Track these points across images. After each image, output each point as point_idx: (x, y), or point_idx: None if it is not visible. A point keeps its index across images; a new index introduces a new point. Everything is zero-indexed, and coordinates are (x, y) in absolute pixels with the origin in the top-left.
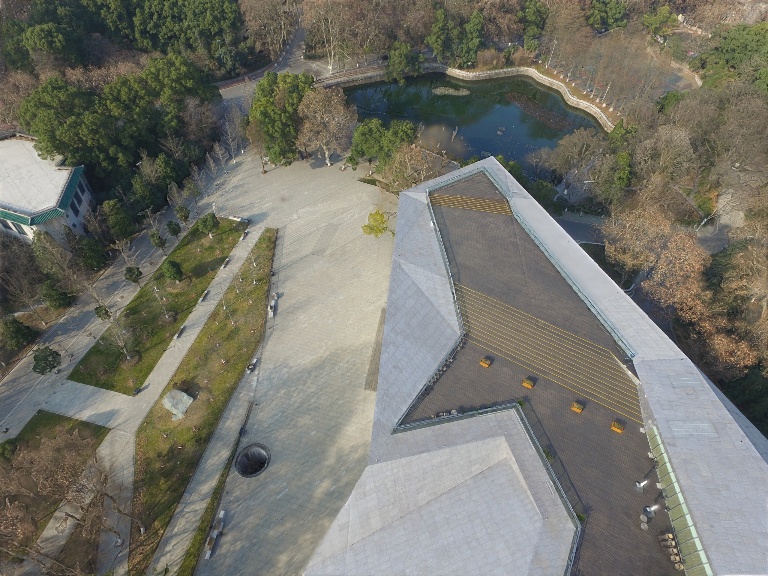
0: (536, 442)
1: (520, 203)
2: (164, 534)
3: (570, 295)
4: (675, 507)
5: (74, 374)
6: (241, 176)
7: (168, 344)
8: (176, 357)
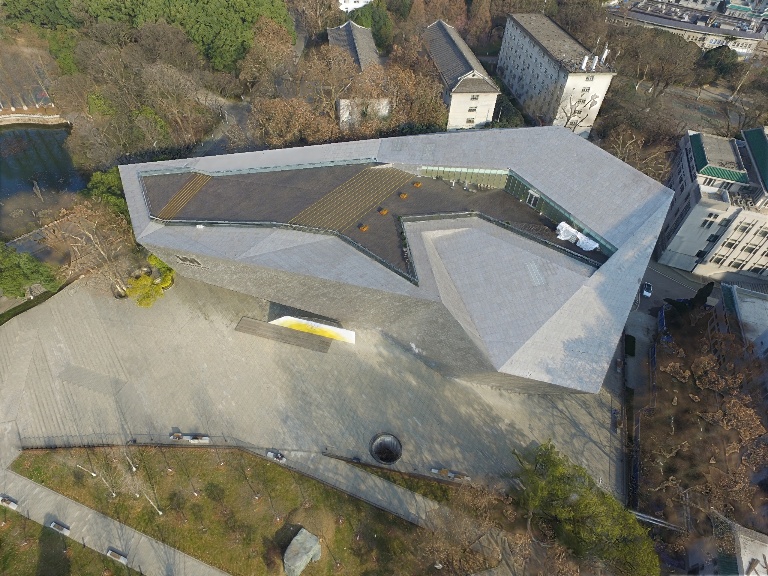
0: None
1: (202, 166)
2: None
3: (314, 171)
4: (466, 177)
5: None
6: None
7: None
8: None
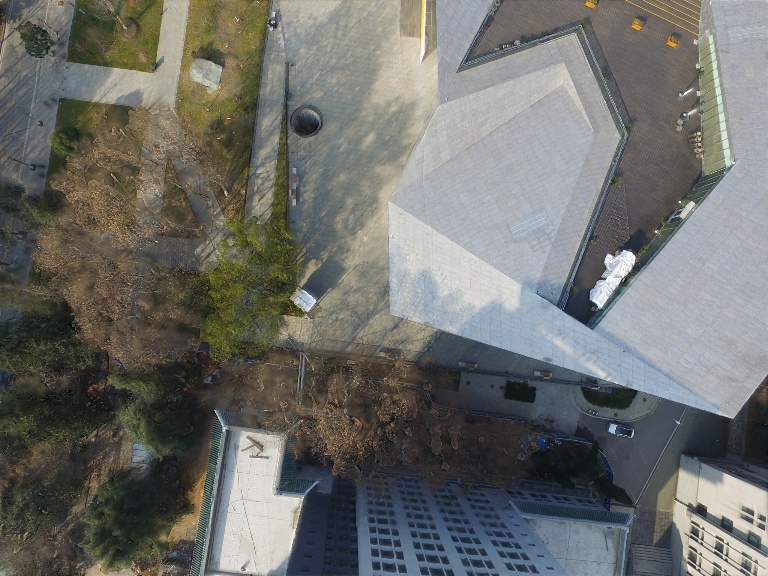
0: (596, 64)
1: None
2: (247, 193)
3: None
4: (710, 109)
5: (73, 54)
6: None
7: (161, 5)
8: (178, 21)
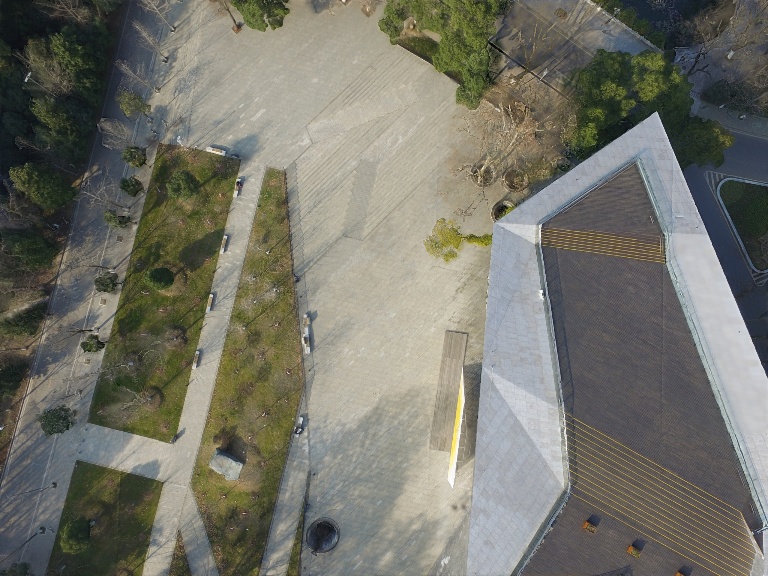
0: None
1: (683, 242)
2: None
3: (714, 424)
4: None
5: (94, 416)
6: (200, 41)
7: (188, 376)
8: (203, 393)
